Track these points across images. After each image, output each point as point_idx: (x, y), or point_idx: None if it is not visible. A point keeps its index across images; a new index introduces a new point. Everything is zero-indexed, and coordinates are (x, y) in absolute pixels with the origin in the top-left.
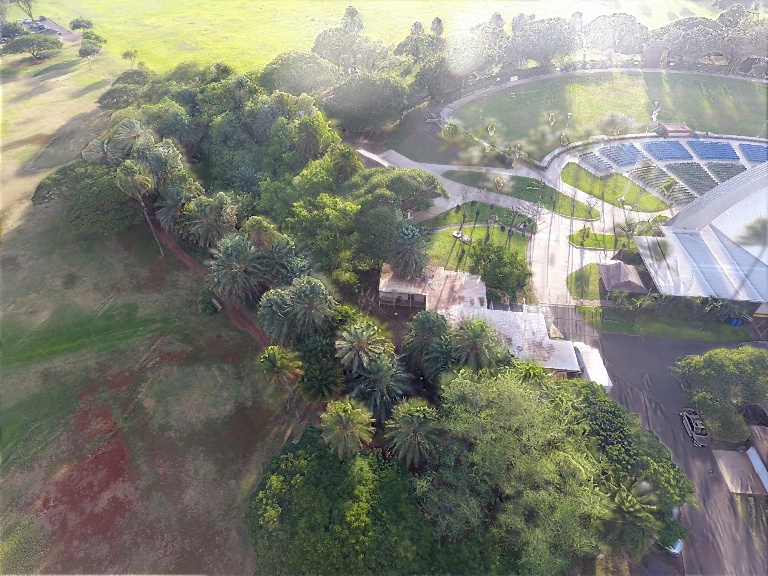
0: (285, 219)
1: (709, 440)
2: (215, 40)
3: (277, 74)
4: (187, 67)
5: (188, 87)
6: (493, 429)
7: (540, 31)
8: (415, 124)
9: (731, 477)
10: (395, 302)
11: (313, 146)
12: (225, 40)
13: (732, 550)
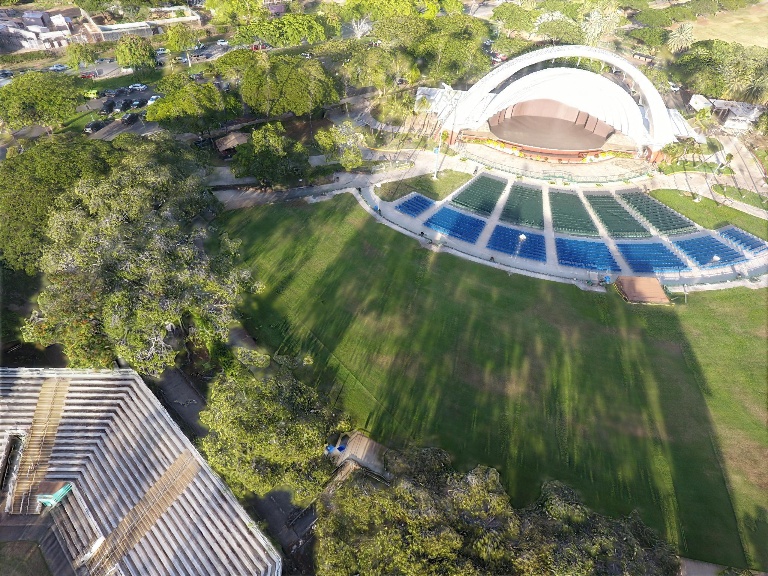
0: None
1: None
2: None
3: None
4: None
5: None
6: None
7: None
8: None
9: None
10: None
11: None
12: None
13: None
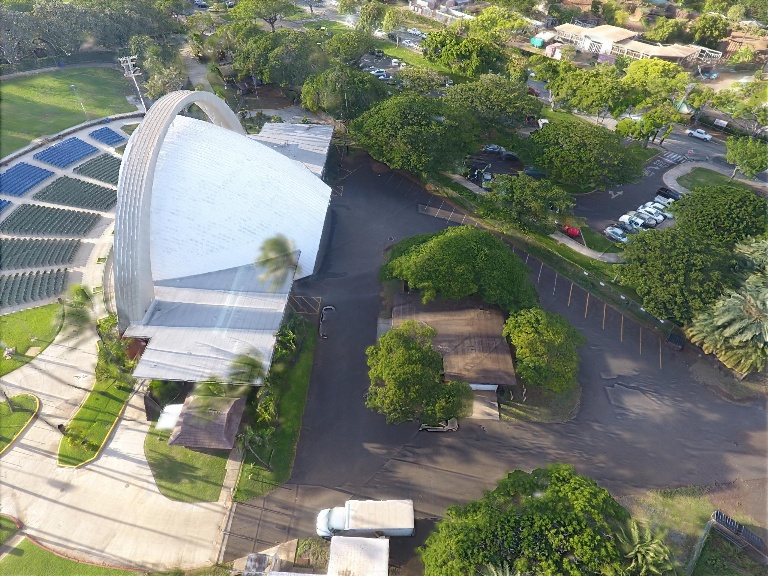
0: None
1: None
2: None
3: None
4: None
5: None
6: None
7: None
8: None
9: (485, 413)
10: None
11: None
12: None
13: (558, 444)
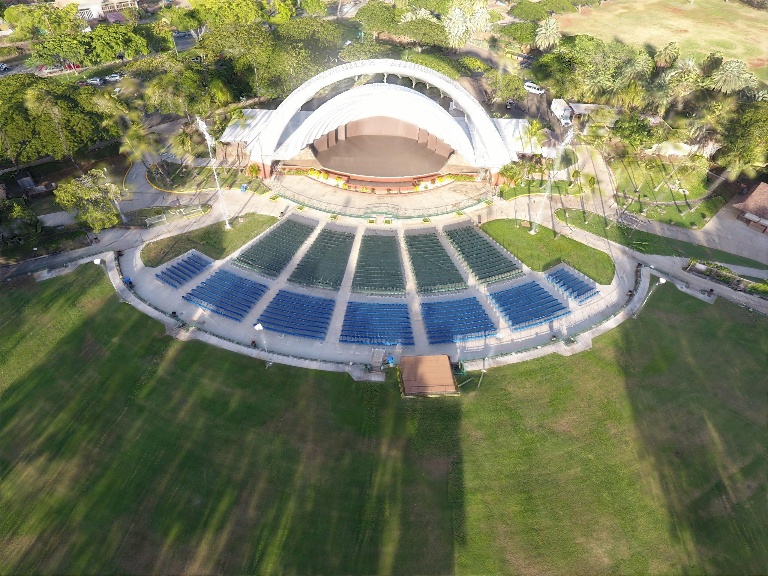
0: None
1: None
2: None
3: None
4: None
5: None
6: None
7: None
8: None
9: None
10: None
11: None
12: None
13: None
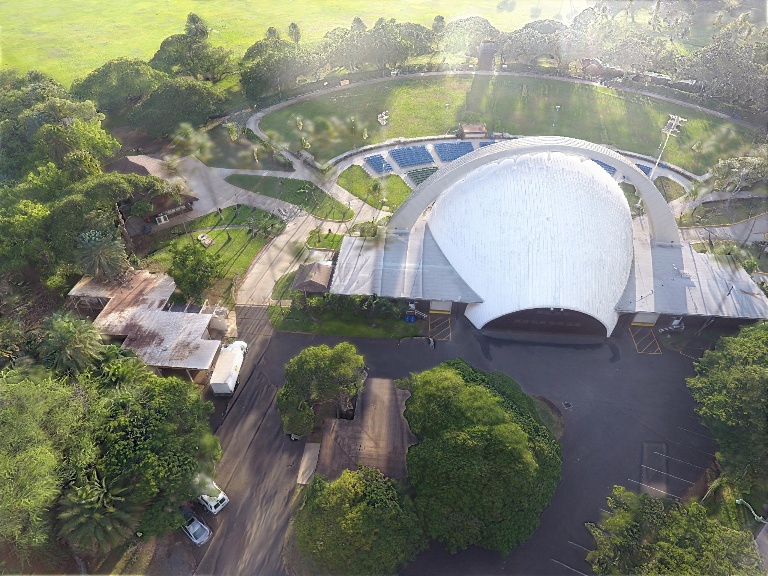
0: None
1: (304, 434)
2: (91, 47)
3: (94, 81)
4: (1, 75)
5: None
6: (1, 428)
7: (365, 36)
8: (224, 129)
9: (305, 469)
10: (90, 305)
11: (63, 153)
12: (100, 46)
13: (260, 539)
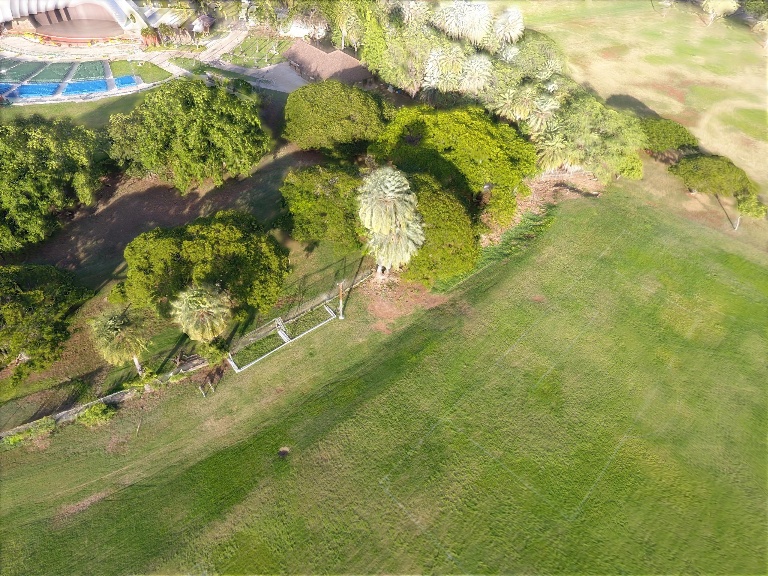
0: (374, 3)
1: None
2: None
3: None
4: None
5: (552, 88)
6: None
7: None
8: (284, 114)
9: None
10: None
11: None
12: None
13: None
